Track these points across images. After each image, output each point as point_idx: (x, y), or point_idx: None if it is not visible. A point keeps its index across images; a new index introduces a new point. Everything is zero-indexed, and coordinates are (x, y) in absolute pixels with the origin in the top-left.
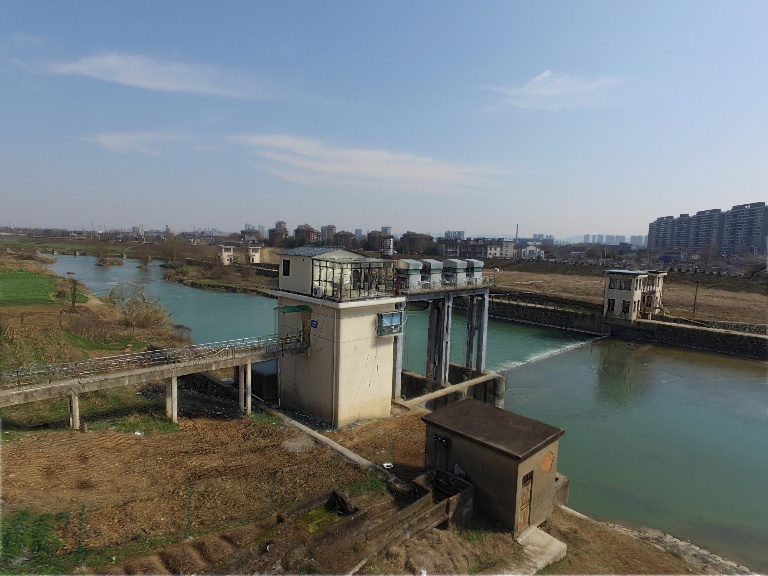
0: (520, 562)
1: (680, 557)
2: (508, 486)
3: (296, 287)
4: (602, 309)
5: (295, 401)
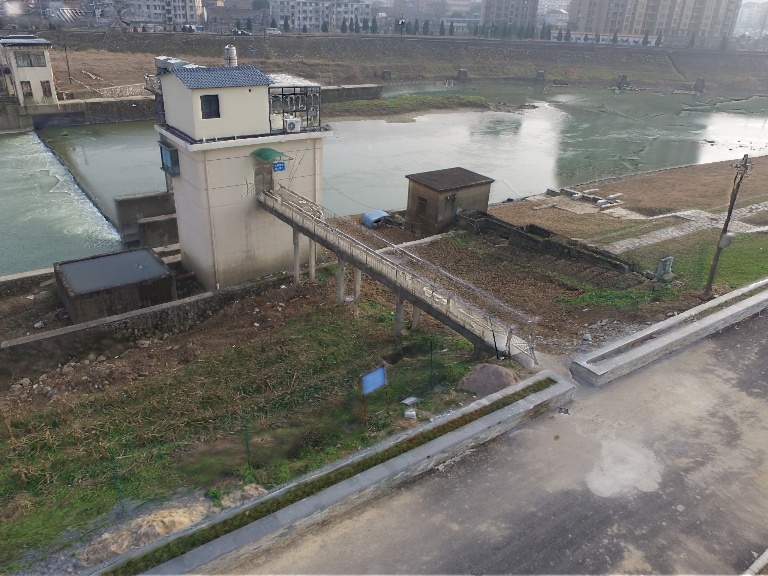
0: None
1: None
2: (485, 200)
3: (238, 130)
4: (3, 97)
5: (250, 270)
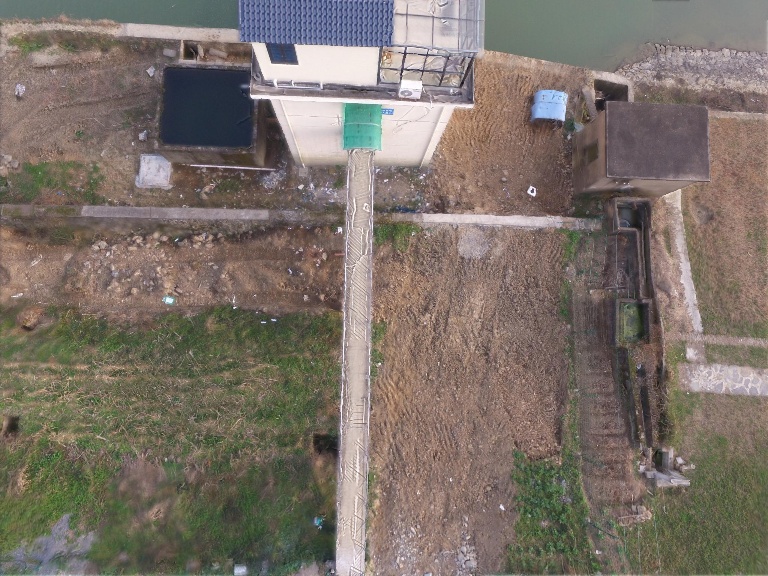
0: (672, 216)
1: (685, 83)
2: None
3: (326, 78)
4: None
5: (339, 161)
